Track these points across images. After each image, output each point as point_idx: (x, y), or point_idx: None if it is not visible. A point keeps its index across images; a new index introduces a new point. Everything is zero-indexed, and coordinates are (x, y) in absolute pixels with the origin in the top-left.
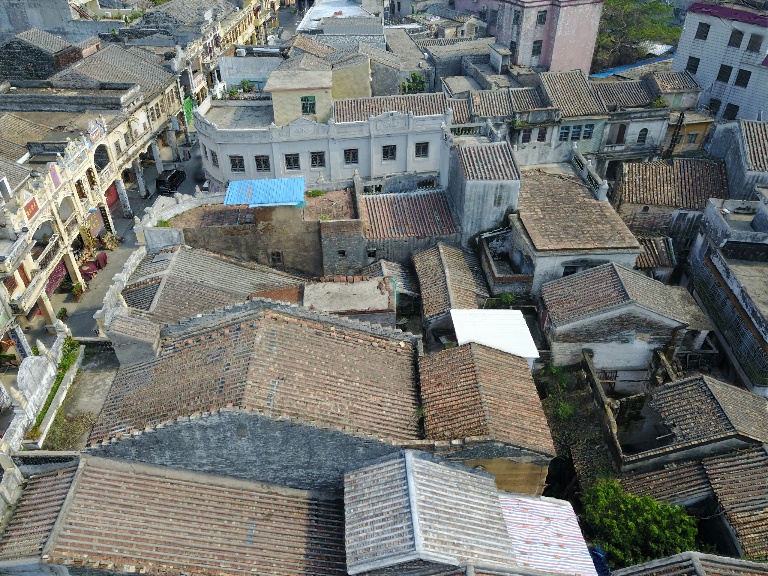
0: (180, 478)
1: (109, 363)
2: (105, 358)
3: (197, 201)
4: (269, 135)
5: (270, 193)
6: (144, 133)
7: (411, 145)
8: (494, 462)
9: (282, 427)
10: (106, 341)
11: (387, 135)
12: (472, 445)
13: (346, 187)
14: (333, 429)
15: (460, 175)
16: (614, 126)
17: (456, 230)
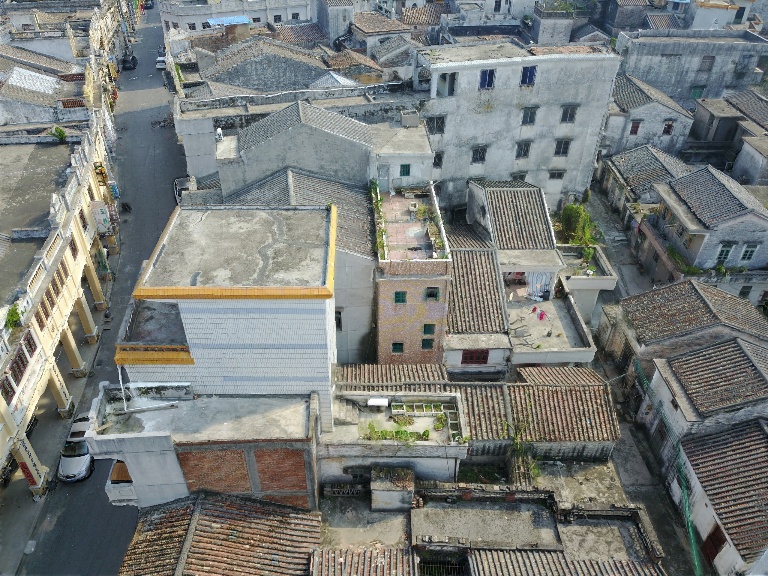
0: (246, 91)
1: (192, 72)
2: (189, 71)
3: (188, 34)
4: (210, 8)
5: (232, 20)
6: (112, 28)
7: (289, 15)
8: (362, 76)
9: (284, 61)
10: (189, 63)
11: (276, 8)
12: (353, 67)
13: (264, 26)
14: (303, 62)
15: (324, 8)
16: (399, 5)
17: (326, 37)
